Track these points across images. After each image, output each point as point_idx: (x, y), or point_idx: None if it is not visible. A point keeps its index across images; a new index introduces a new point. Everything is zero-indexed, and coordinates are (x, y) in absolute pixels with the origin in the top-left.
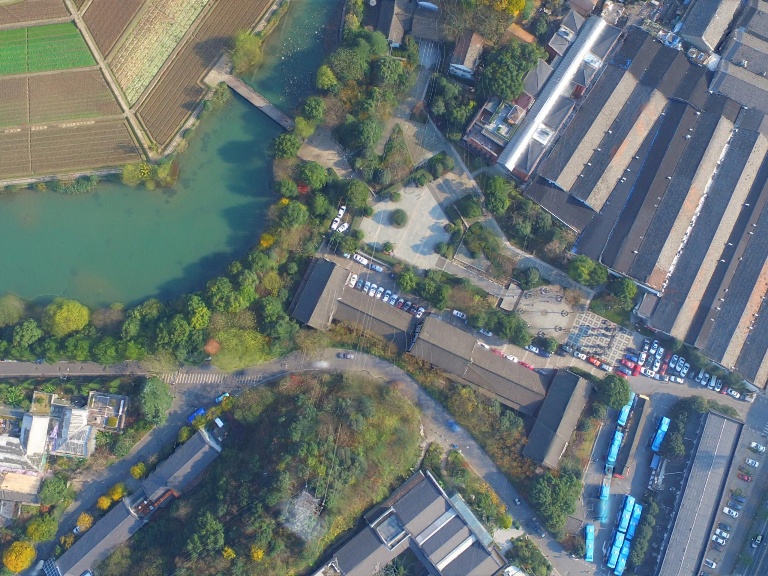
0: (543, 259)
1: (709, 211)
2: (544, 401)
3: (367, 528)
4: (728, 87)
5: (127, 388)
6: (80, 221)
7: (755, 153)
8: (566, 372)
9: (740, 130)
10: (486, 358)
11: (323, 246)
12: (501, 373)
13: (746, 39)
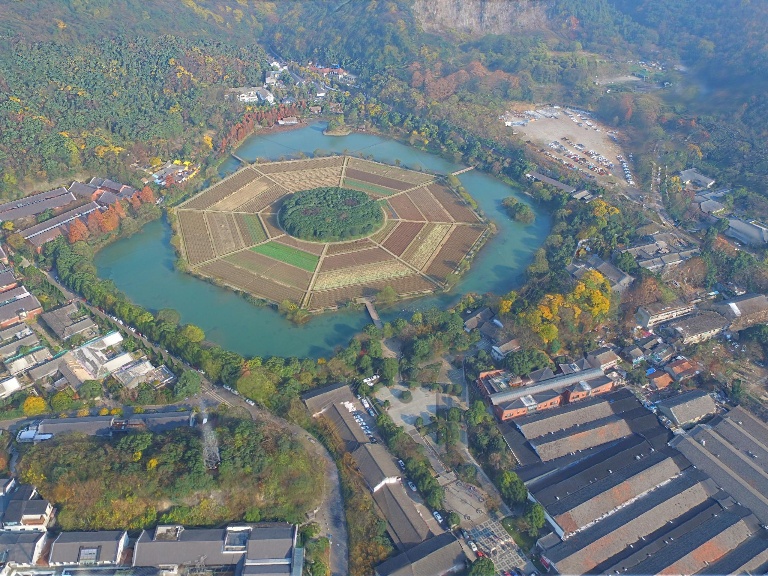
0: (486, 471)
1: (634, 507)
2: (420, 544)
3: (223, 529)
4: (683, 447)
5: None
6: (242, 313)
7: (690, 492)
8: (451, 533)
9: (684, 475)
10: (399, 492)
11: (350, 386)
12: (402, 505)
13: (709, 430)
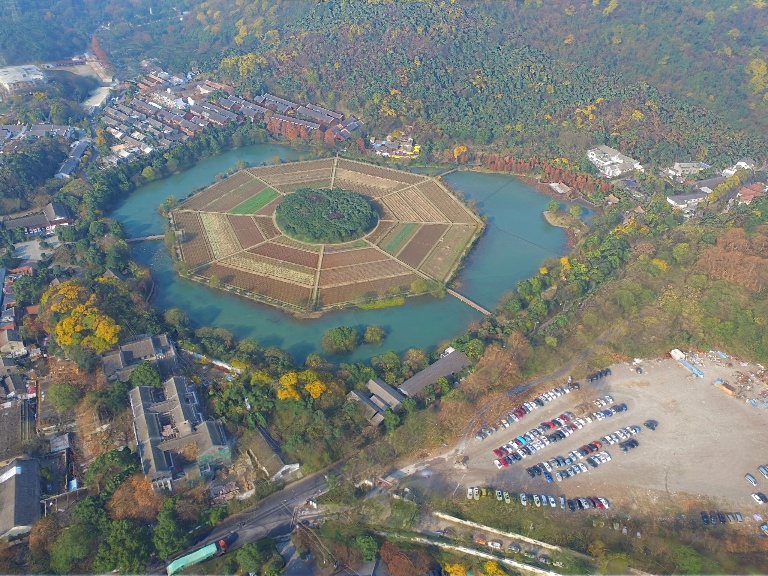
0: None
1: None
2: None
3: None
4: None
5: None
6: None
7: None
8: None
9: None
10: None
11: None
12: None
13: None
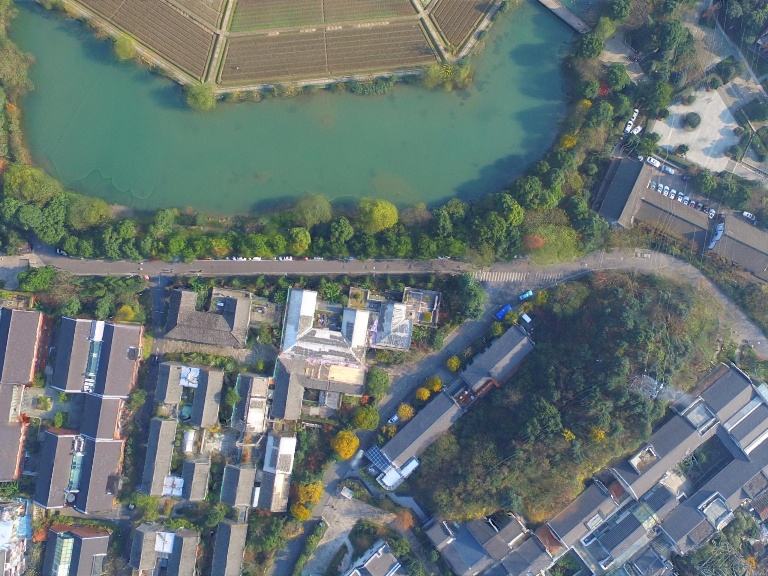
0: None
1: None
2: None
3: (677, 416)
4: None
5: (441, 284)
6: (377, 122)
7: None
8: None
9: None
10: None
11: (616, 149)
12: None
13: None
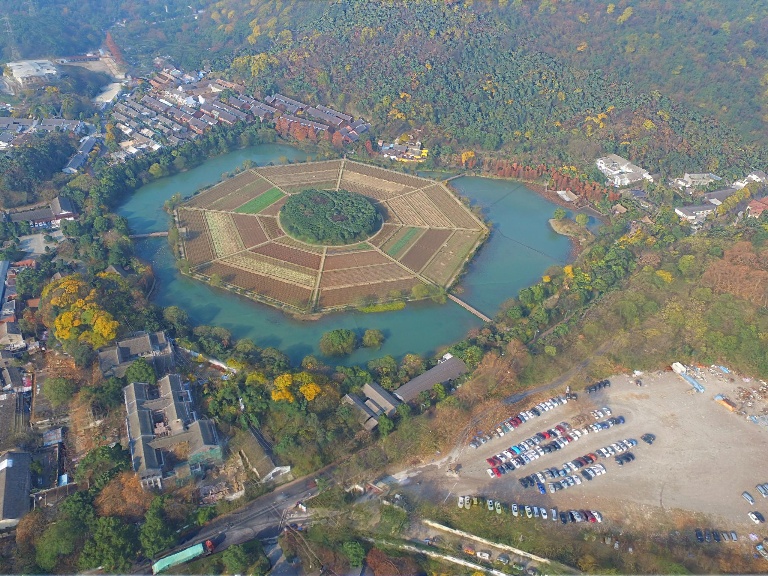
0: None
1: None
2: None
3: None
4: None
5: None
6: None
7: None
8: None
9: None
10: None
11: None
12: None
13: None
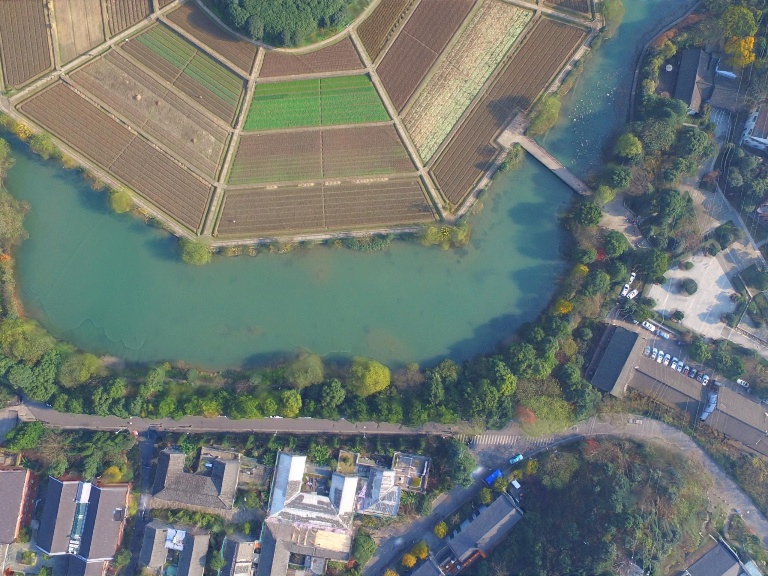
0: None
1: None
2: None
3: None
4: None
5: (431, 450)
6: (372, 279)
7: None
8: None
9: None
10: None
11: (612, 311)
12: None
13: None
